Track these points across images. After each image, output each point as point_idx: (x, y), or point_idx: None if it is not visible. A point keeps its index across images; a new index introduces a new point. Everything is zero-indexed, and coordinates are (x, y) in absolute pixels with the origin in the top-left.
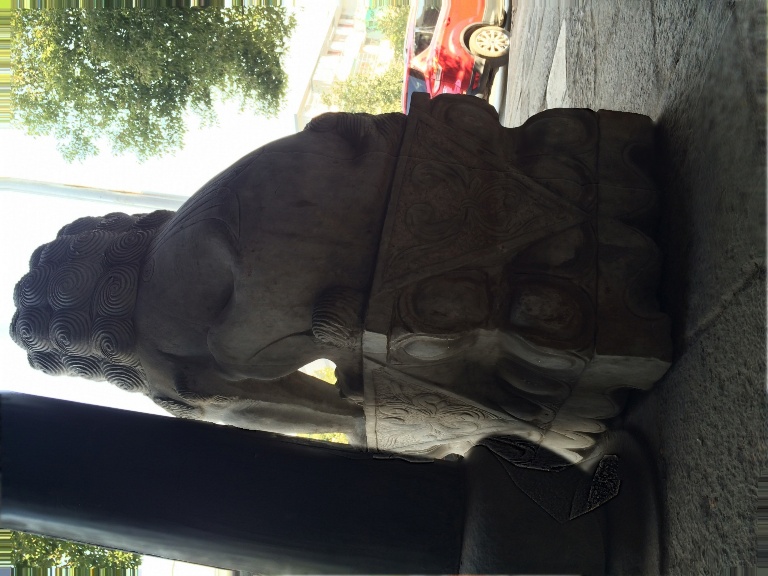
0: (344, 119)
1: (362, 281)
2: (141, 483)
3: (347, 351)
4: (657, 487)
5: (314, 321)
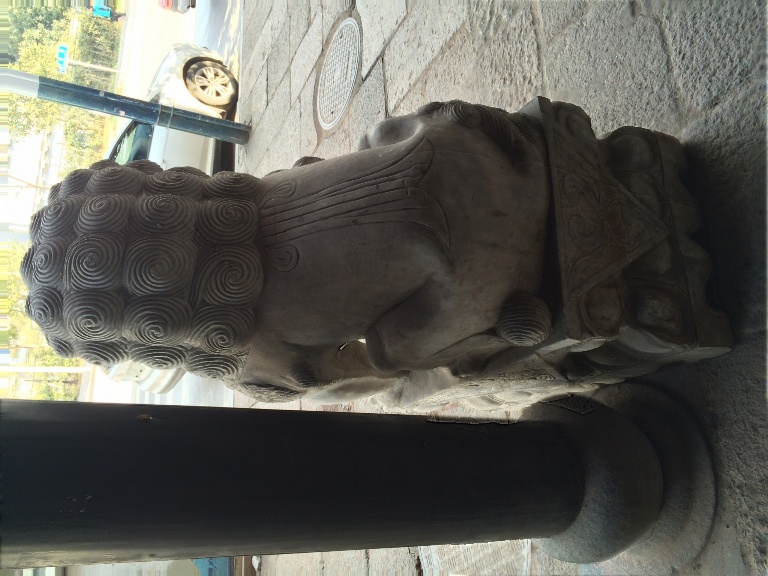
0: (488, 116)
1: (535, 286)
2: (348, 489)
3: (504, 344)
4: (704, 433)
5: (518, 328)
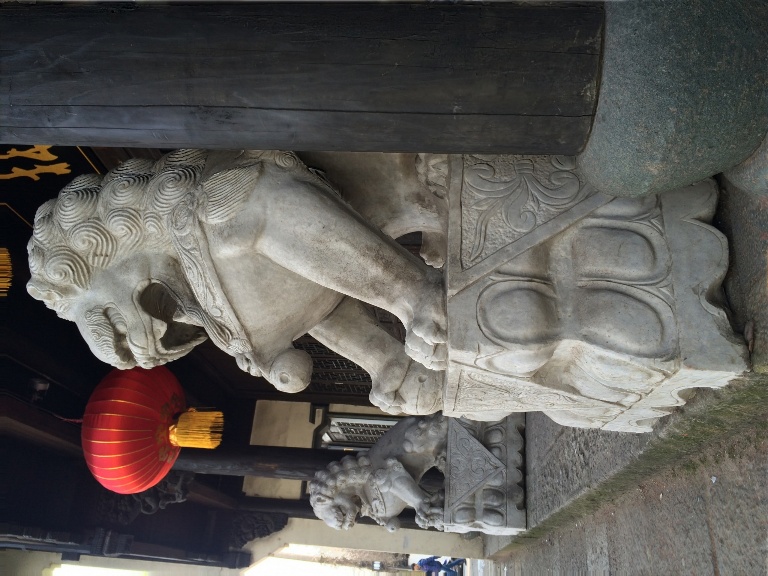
0: None
1: None
2: None
3: None
4: None
5: None
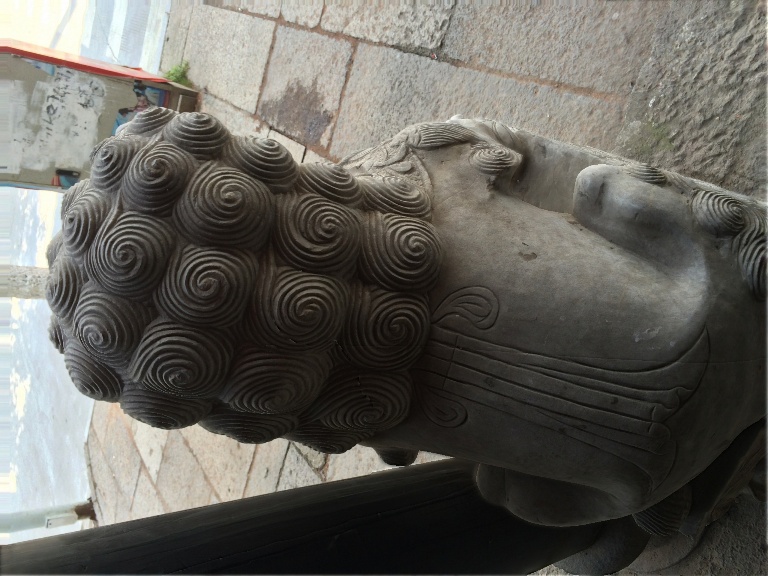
0: None
1: None
2: None
3: None
4: None
5: (655, 528)
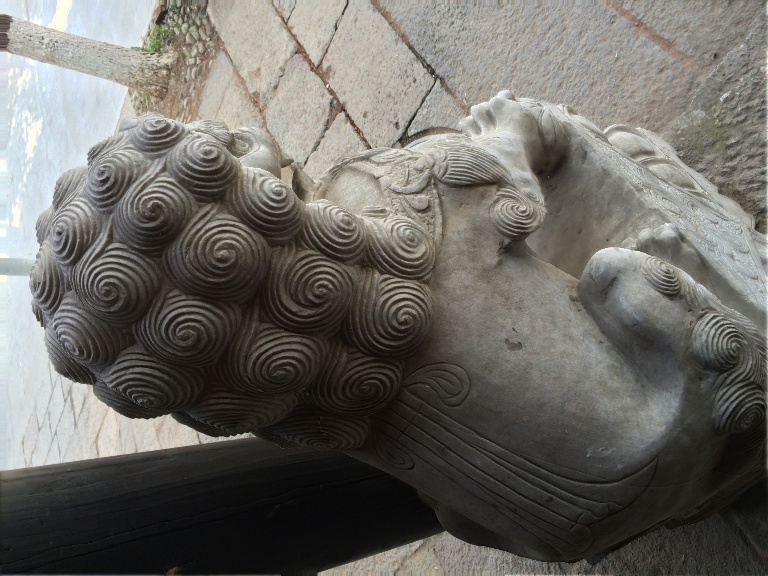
0: (756, 424)
1: None
2: None
3: None
4: None
5: None
